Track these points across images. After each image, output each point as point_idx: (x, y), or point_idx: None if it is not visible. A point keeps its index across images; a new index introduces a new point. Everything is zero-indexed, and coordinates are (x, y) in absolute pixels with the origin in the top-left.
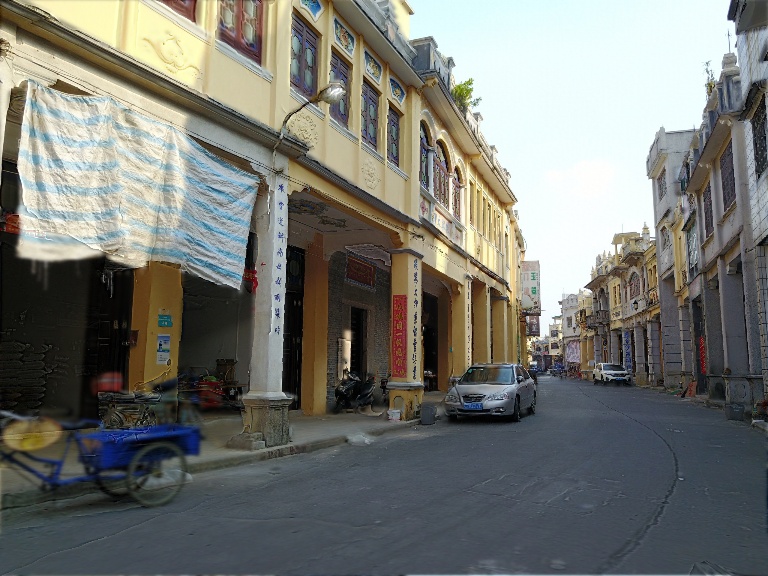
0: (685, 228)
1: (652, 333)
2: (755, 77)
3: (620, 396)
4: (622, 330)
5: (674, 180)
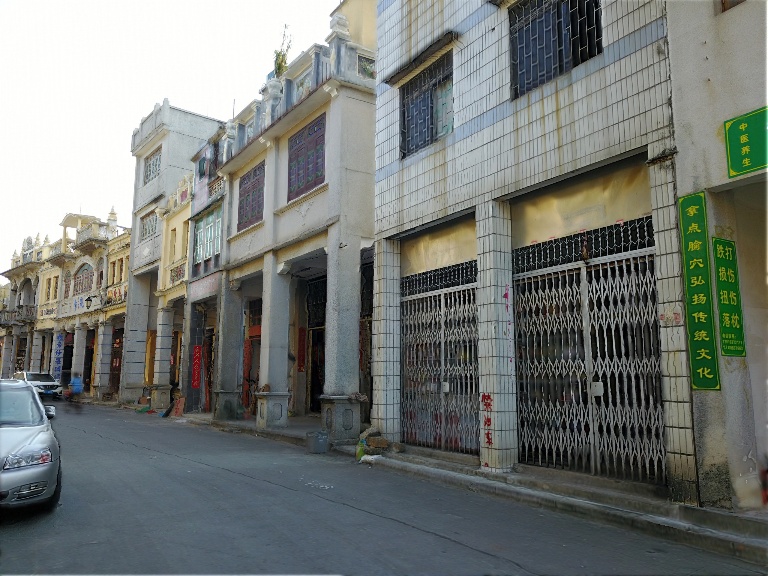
0: (195, 217)
1: (104, 337)
2: (426, 33)
3: (90, 419)
4: (55, 331)
5: (172, 163)
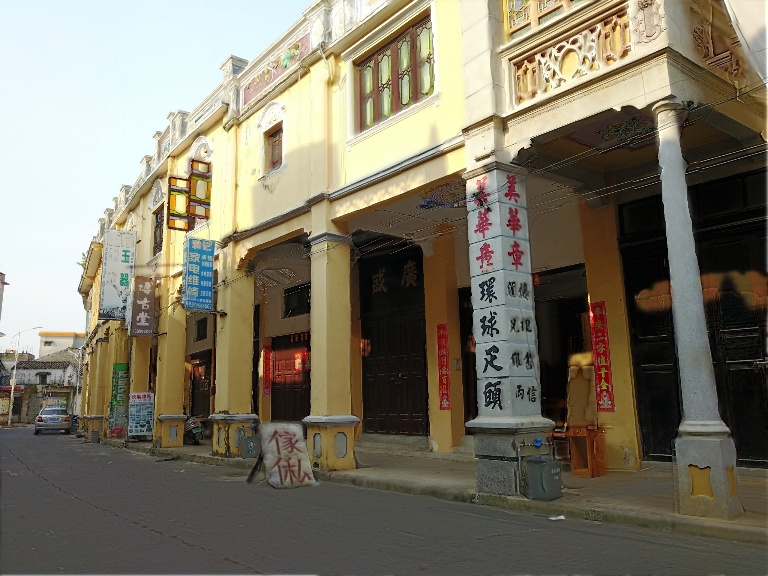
0: None
1: None
2: None
3: None
4: None
5: None
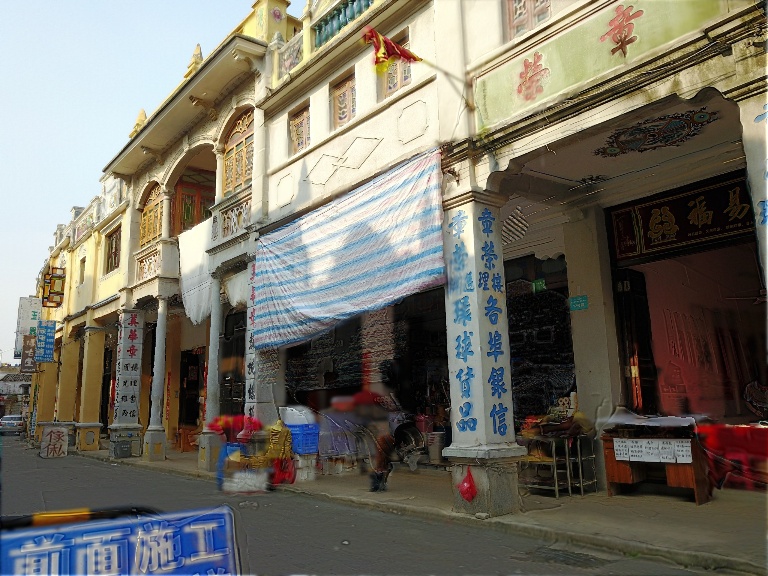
0: None
1: None
2: None
3: None
4: None
5: None
